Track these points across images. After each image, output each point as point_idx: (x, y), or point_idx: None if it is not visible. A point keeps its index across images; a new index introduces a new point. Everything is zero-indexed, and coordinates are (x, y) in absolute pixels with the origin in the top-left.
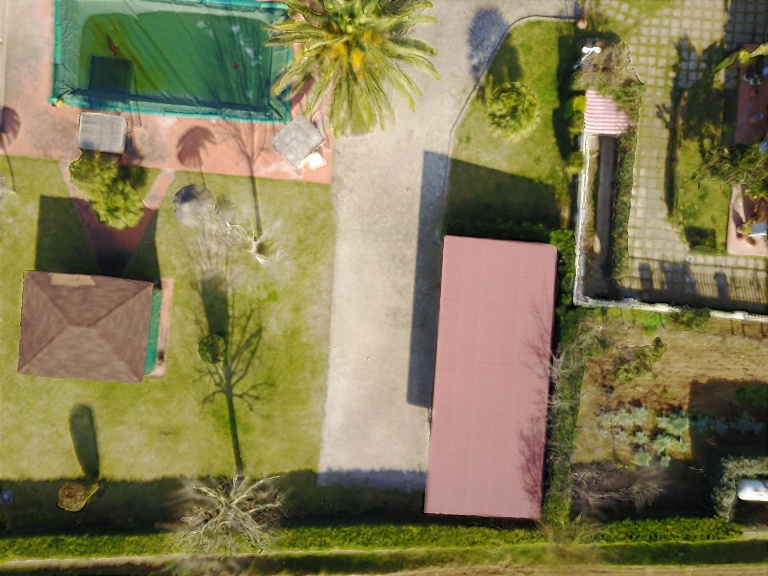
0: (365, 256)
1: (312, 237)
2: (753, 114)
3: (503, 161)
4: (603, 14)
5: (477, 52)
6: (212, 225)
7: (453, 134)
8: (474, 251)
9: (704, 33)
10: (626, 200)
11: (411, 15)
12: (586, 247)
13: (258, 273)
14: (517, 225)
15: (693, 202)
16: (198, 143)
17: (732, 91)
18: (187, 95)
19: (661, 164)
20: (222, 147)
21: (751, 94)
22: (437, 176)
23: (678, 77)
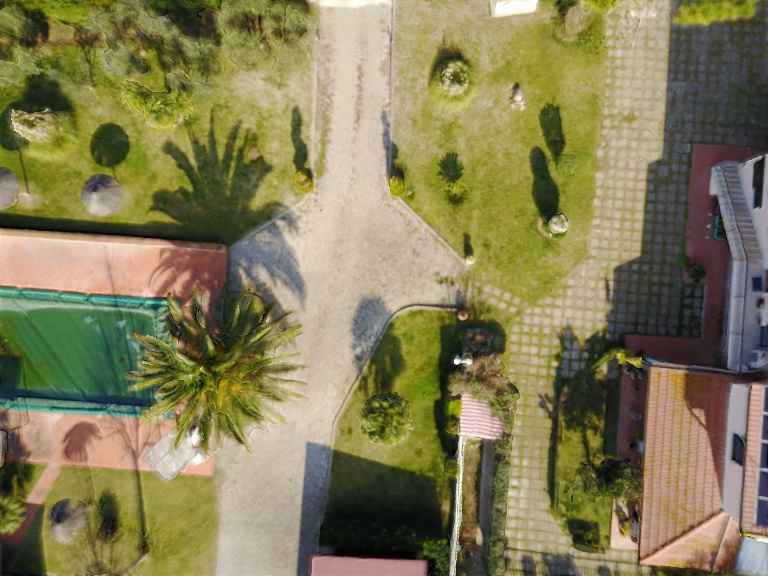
0: (248, 548)
1: (195, 529)
2: (634, 410)
3: (385, 453)
4: (485, 302)
5: (360, 341)
6: (97, 519)
7: (335, 425)
8: (343, 570)
9: (586, 323)
10: (501, 507)
11: (277, 343)
12: (469, 539)
13: (142, 566)
14: (391, 534)
15: (576, 494)
16: (84, 438)
17: (615, 382)
18: (74, 389)
19: (544, 454)
20: (107, 441)
21: (632, 389)
22: (320, 466)
23: (561, 366)
